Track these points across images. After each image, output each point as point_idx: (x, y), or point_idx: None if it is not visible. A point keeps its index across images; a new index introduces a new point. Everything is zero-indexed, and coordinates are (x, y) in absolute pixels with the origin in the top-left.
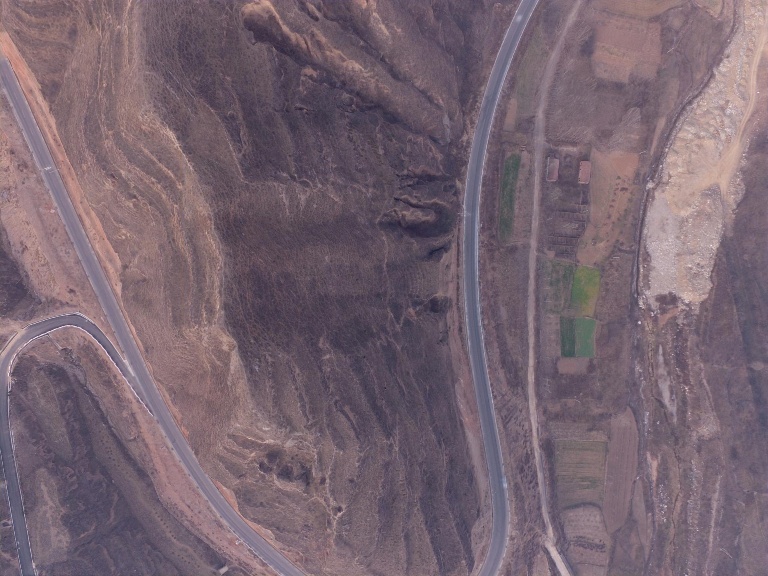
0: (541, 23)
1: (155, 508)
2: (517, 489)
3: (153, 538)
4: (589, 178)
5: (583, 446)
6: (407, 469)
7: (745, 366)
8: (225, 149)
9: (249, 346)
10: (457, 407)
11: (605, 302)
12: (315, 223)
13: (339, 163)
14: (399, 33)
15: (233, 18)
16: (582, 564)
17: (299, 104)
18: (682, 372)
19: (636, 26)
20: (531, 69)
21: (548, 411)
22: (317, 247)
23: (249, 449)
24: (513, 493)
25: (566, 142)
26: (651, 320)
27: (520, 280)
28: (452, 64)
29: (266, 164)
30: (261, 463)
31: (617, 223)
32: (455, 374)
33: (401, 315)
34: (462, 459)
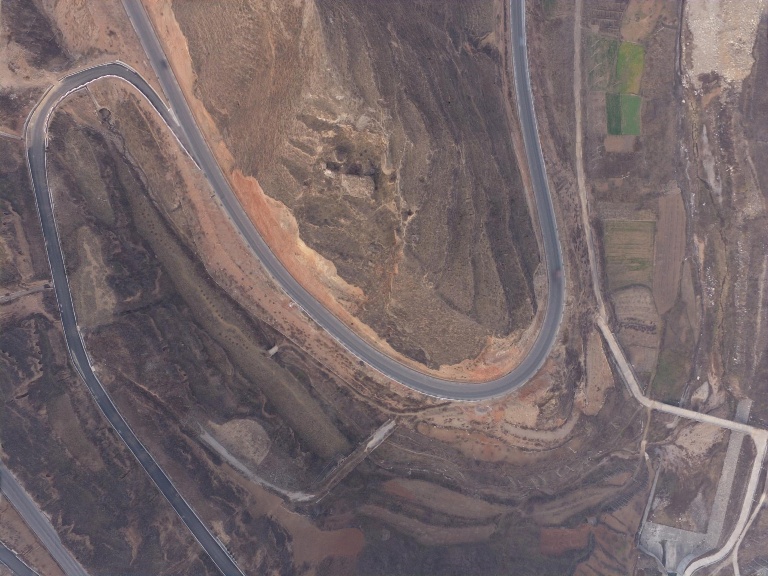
0: None
1: (200, 285)
2: (572, 255)
3: (199, 318)
4: None
5: (631, 226)
6: (473, 188)
7: None
8: None
9: None
10: (514, 153)
11: (650, 78)
12: None
13: None
14: None
15: None
16: (634, 346)
17: None
18: (726, 151)
19: None
20: None
21: (596, 190)
22: None
23: (319, 133)
24: (568, 258)
25: None
26: (695, 99)
27: (565, 55)
28: None
29: None
30: (328, 163)
31: None
32: (510, 124)
33: (459, 44)
34: (522, 201)
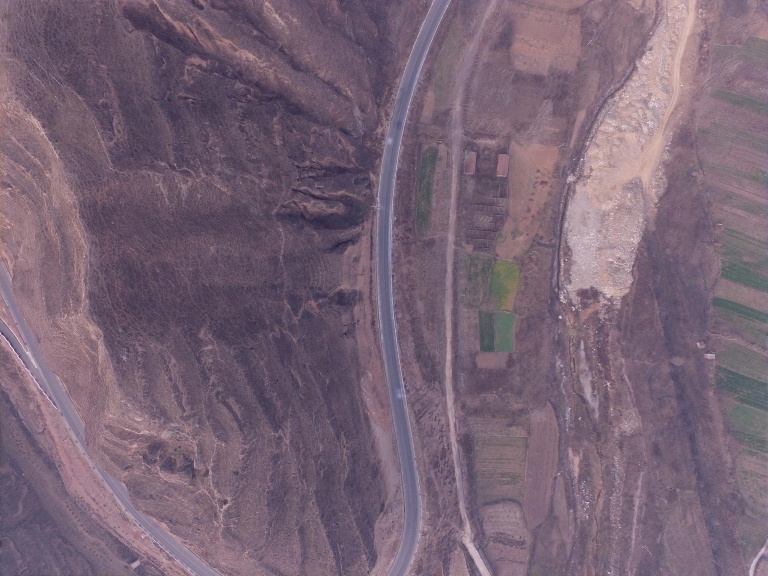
0: (459, 15)
1: (66, 501)
2: (430, 484)
3: (64, 531)
4: (507, 171)
5: (503, 442)
6: (300, 462)
7: (667, 361)
8: (93, 137)
9: (117, 335)
10: (362, 401)
11: (524, 296)
12: (201, 213)
13: (229, 153)
14: (295, 23)
15: (109, 6)
16: (502, 561)
17: (183, 93)
18: (603, 367)
19: (556, 18)
20: (449, 61)
21: (467, 406)
22: (200, 237)
23: (127, 440)
24: (425, 488)
25: (484, 135)
26: (572, 315)
27: (438, 274)
28: (361, 55)
29: (142, 153)
30: (145, 455)
31: (537, 217)
32: (362, 367)
33: (300, 307)
34: (365, 453)
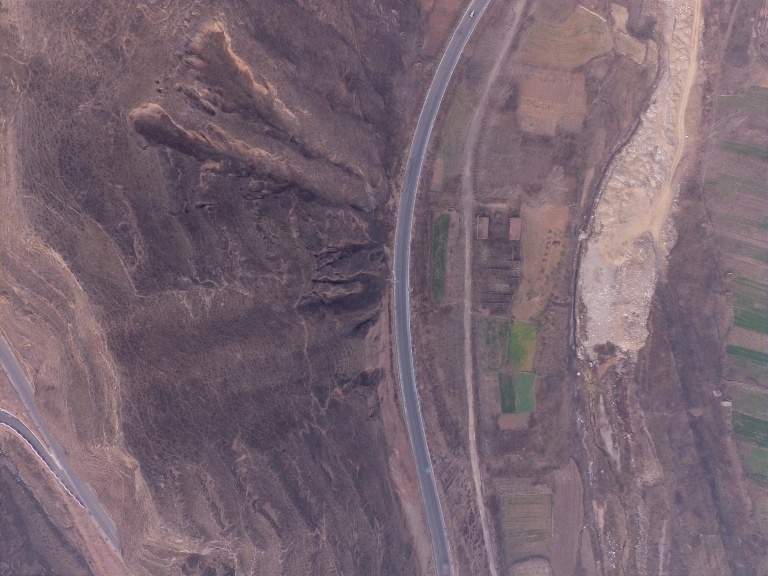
0: (464, 80)
1: None
2: (461, 552)
3: None
4: (519, 234)
5: (528, 500)
6: (337, 555)
7: (685, 411)
8: (116, 265)
9: (153, 464)
10: (391, 481)
11: (543, 356)
12: (225, 320)
13: (248, 255)
14: (306, 114)
15: (121, 124)
16: None
17: (200, 201)
18: (623, 420)
19: (560, 77)
20: (456, 127)
21: (491, 468)
22: (226, 347)
23: (166, 558)
24: (457, 557)
25: (495, 199)
26: (590, 370)
27: (456, 340)
28: (370, 132)
29: (164, 271)
30: (184, 566)
31: (551, 277)
32: (389, 446)
33: (326, 397)
34: (398, 534)
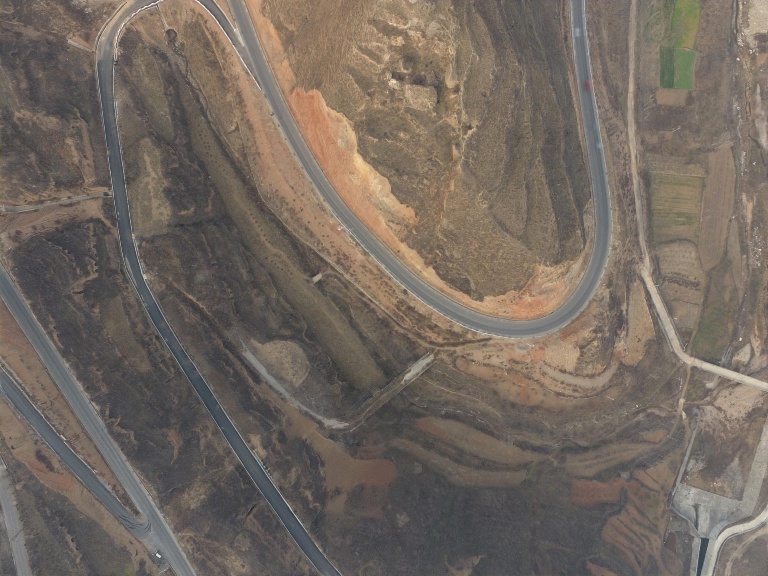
0: None
1: (250, 209)
2: (620, 200)
3: (247, 240)
4: None
5: (680, 181)
6: (531, 113)
7: None
8: None
9: None
10: (570, 89)
11: (705, 33)
12: None
13: None
14: None
15: None
16: (676, 301)
17: None
18: None
19: None
20: None
21: (646, 142)
22: None
23: (388, 39)
24: (616, 202)
25: None
26: (749, 58)
27: (621, 6)
28: None
29: None
30: (393, 73)
31: None
32: None
33: None
34: (576, 136)
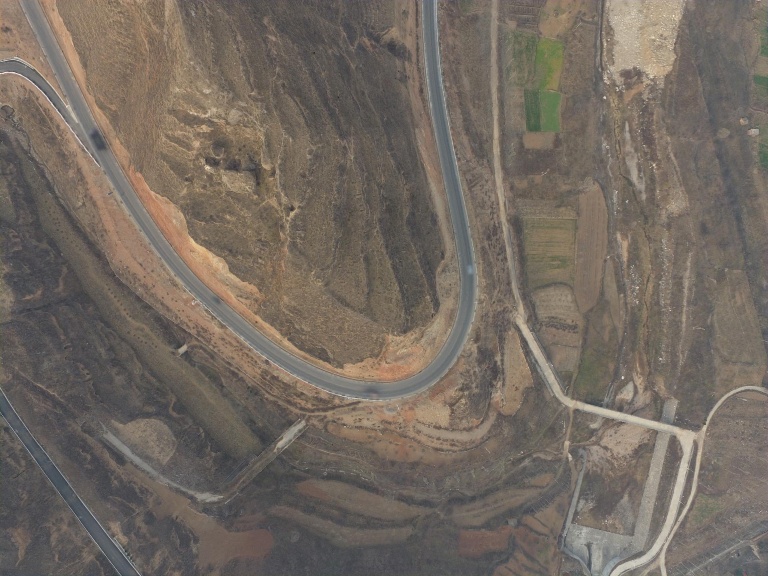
0: None
1: (108, 284)
2: (484, 253)
3: (106, 316)
4: None
5: (552, 224)
6: (364, 184)
7: (711, 139)
8: None
9: None
10: (418, 149)
11: (569, 74)
12: None
13: None
14: None
15: None
16: (555, 345)
17: None
18: (649, 148)
19: None
20: None
21: (515, 188)
22: None
23: (191, 128)
24: (480, 255)
25: None
26: (616, 96)
27: (482, 51)
28: None
29: None
30: (207, 158)
31: None
32: (415, 120)
33: (355, 39)
34: (424, 197)
